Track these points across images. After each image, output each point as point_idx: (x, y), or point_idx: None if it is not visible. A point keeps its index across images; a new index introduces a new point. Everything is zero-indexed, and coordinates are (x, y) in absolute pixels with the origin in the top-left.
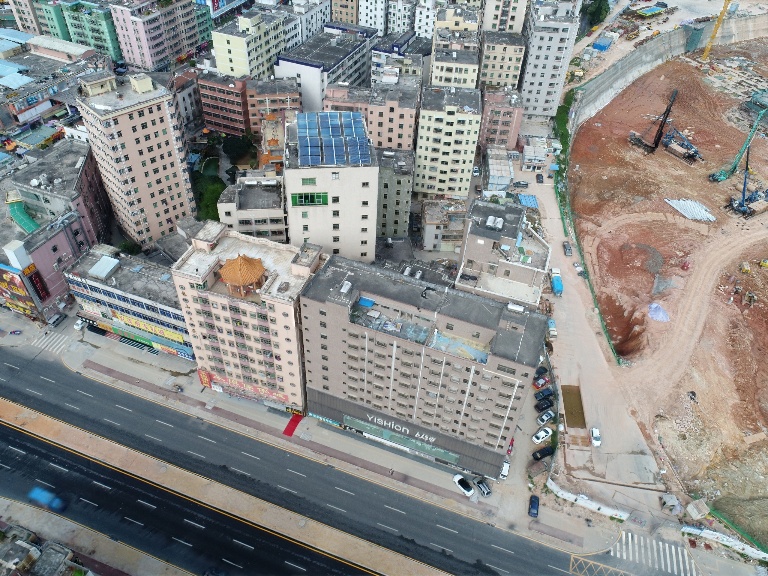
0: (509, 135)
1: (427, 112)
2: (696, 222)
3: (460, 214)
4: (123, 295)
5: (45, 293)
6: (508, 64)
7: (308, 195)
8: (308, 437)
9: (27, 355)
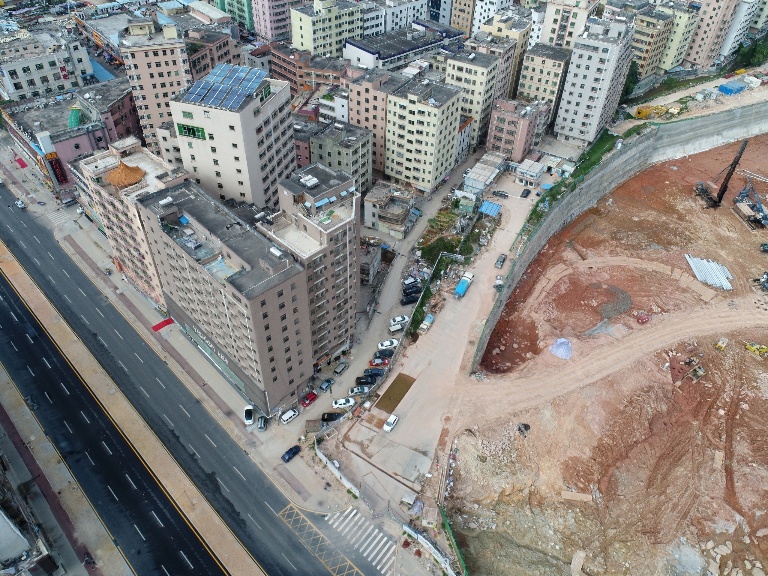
0: (515, 146)
1: (393, 97)
2: (705, 286)
3: (403, 200)
4: None
5: (63, 178)
6: (546, 78)
7: (190, 127)
8: (167, 336)
9: (38, 220)
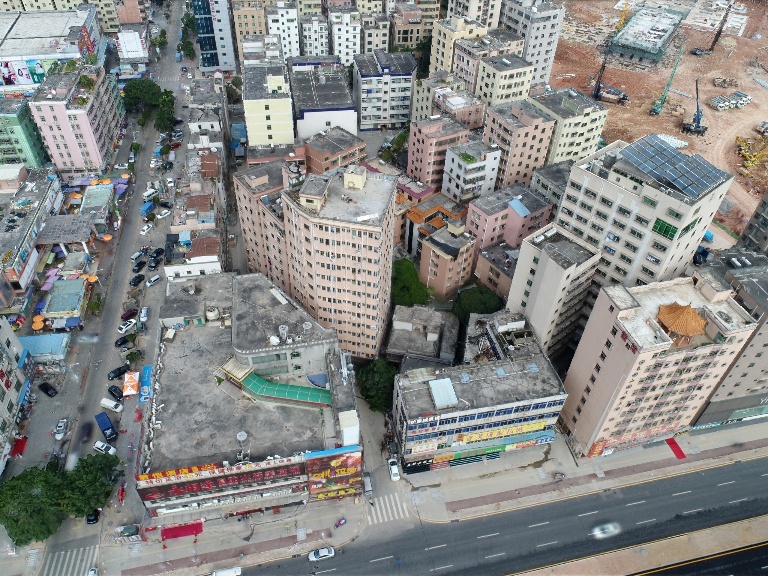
0: None
1: (569, 120)
2: None
3: None
4: (489, 410)
5: None
6: None
7: (689, 224)
8: (697, 450)
9: (381, 538)
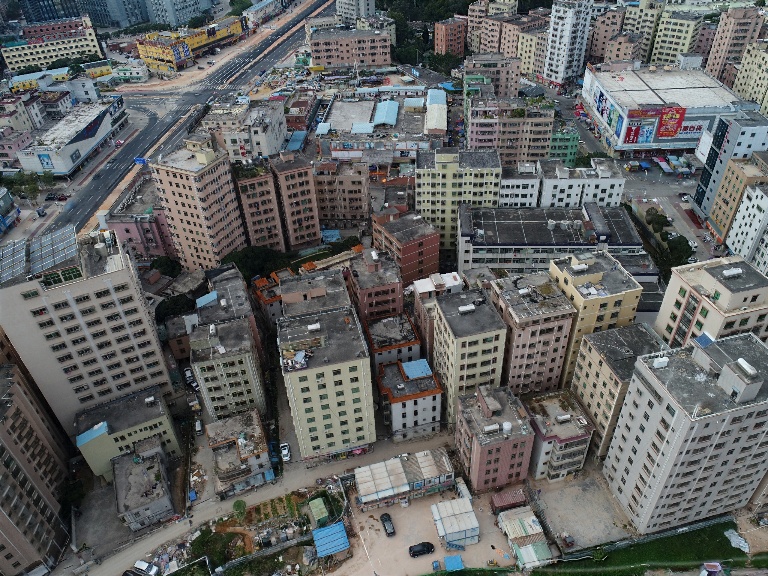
0: (472, 465)
1: None
2: None
3: None
4: None
5: None
6: (602, 389)
7: None
8: None
9: None
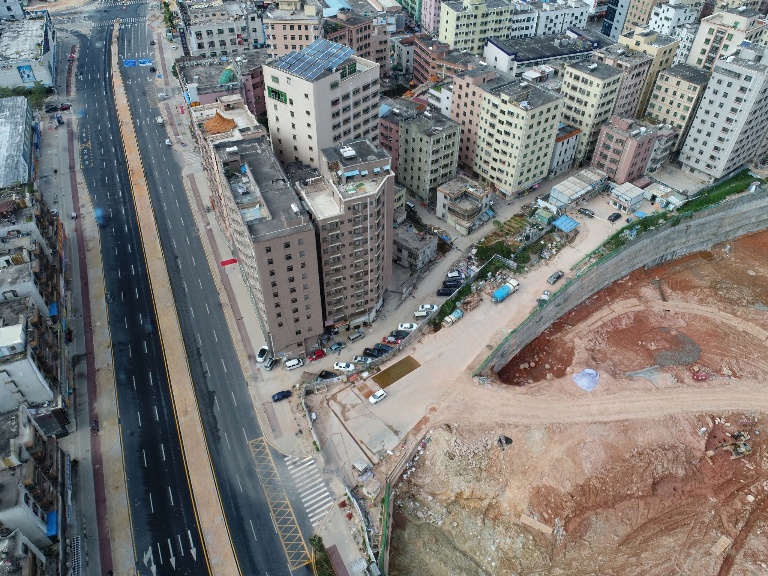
0: (620, 166)
1: (488, 94)
2: None
3: (475, 197)
4: None
5: None
6: (679, 101)
7: (276, 91)
8: (229, 272)
9: (175, 157)
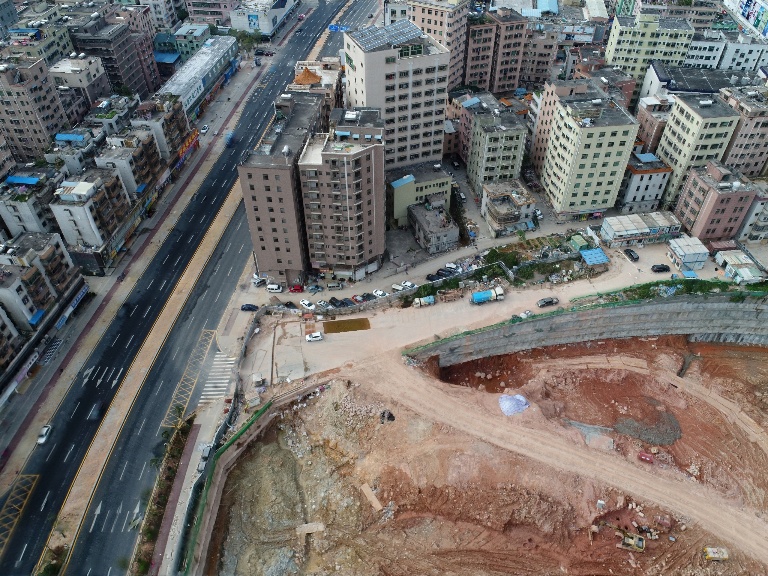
0: (698, 219)
1: (559, 105)
2: None
3: None
4: None
5: None
6: None
7: (349, 57)
8: None
9: None
